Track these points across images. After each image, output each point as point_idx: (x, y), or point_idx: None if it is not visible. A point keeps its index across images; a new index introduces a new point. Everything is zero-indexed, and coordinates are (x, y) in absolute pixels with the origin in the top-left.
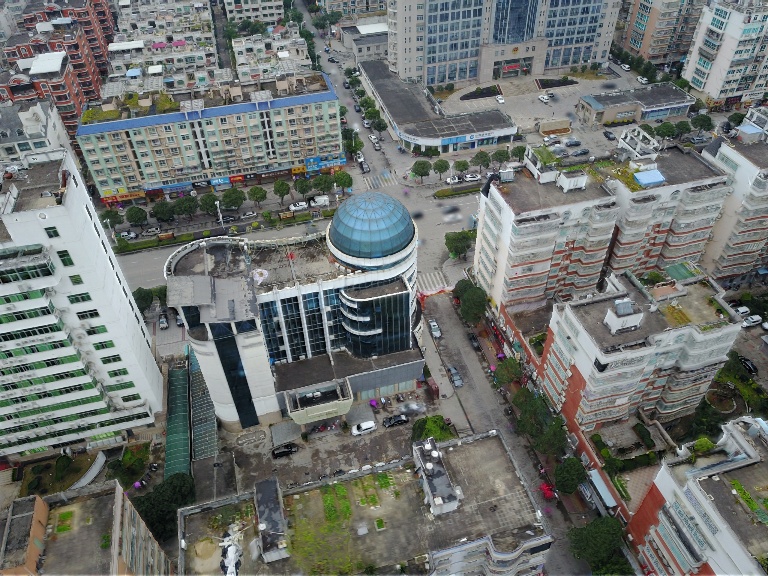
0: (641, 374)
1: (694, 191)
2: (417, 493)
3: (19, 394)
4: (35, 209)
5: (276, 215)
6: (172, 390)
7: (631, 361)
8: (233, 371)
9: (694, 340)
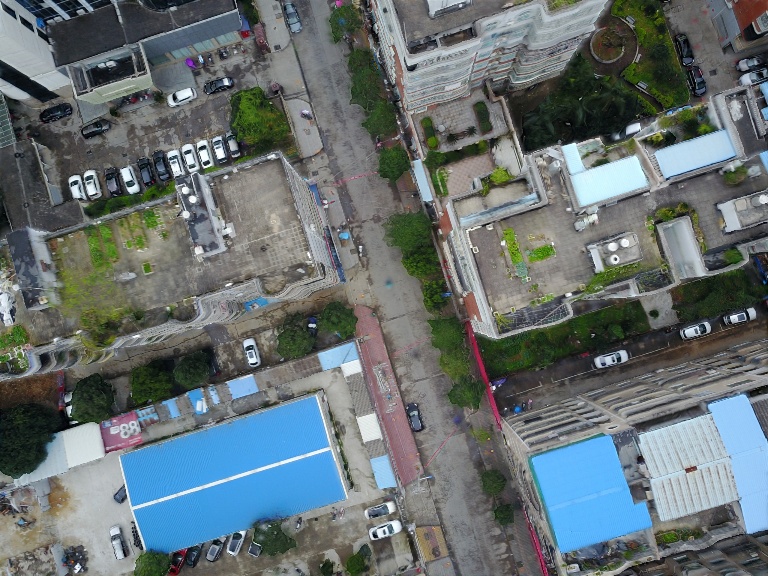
0: (471, 62)
1: None
2: (187, 232)
3: None
4: None
5: None
6: None
7: (449, 56)
8: None
9: (541, 19)
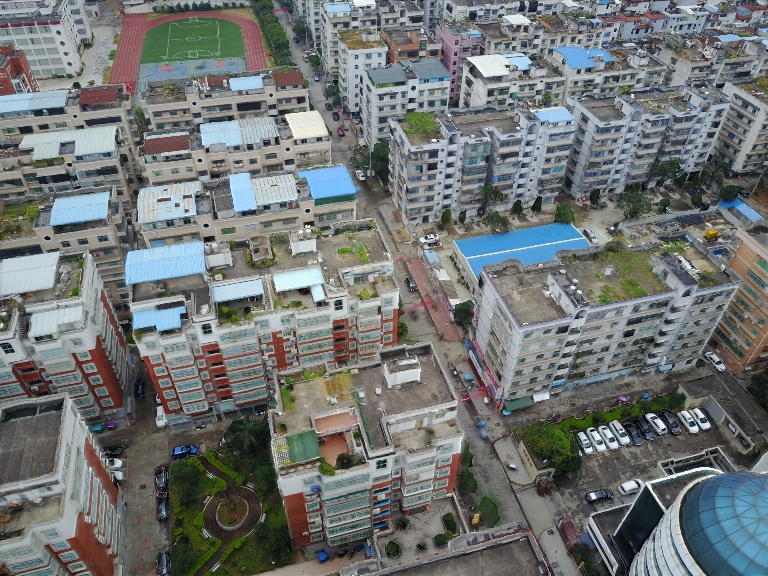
0: None
1: None
2: None
3: None
4: None
5: None
6: None
7: None
8: None
9: None
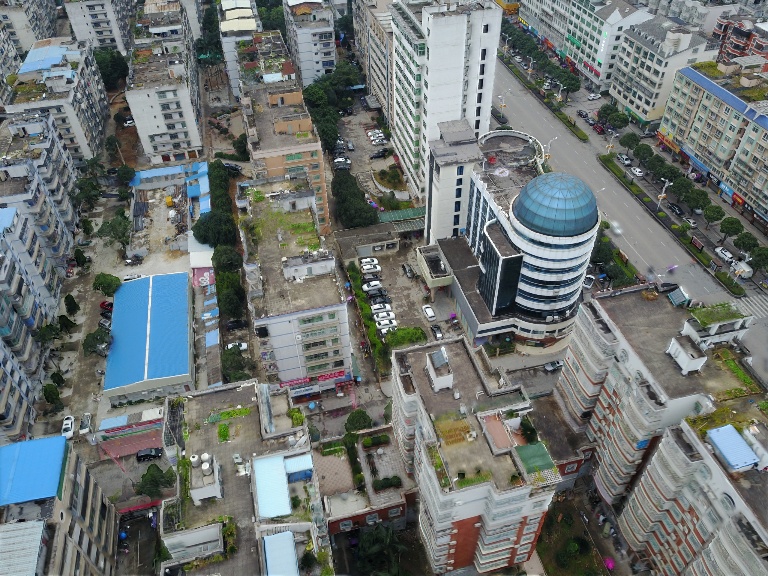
0: (406, 422)
1: (739, 524)
2: None
3: None
4: (428, 13)
5: (702, 241)
6: None
7: None
8: None
9: None
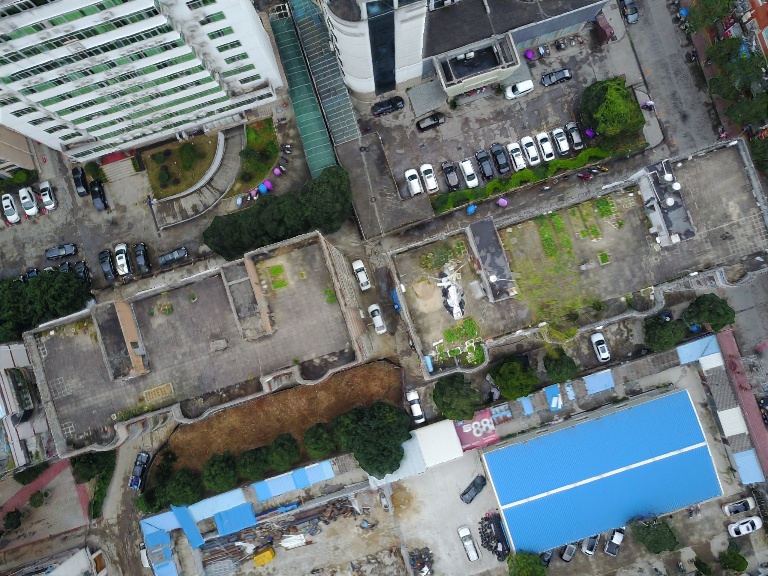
0: None
1: None
2: (641, 221)
3: (129, 100)
4: None
5: None
6: (282, 51)
7: None
8: (381, 46)
9: None
